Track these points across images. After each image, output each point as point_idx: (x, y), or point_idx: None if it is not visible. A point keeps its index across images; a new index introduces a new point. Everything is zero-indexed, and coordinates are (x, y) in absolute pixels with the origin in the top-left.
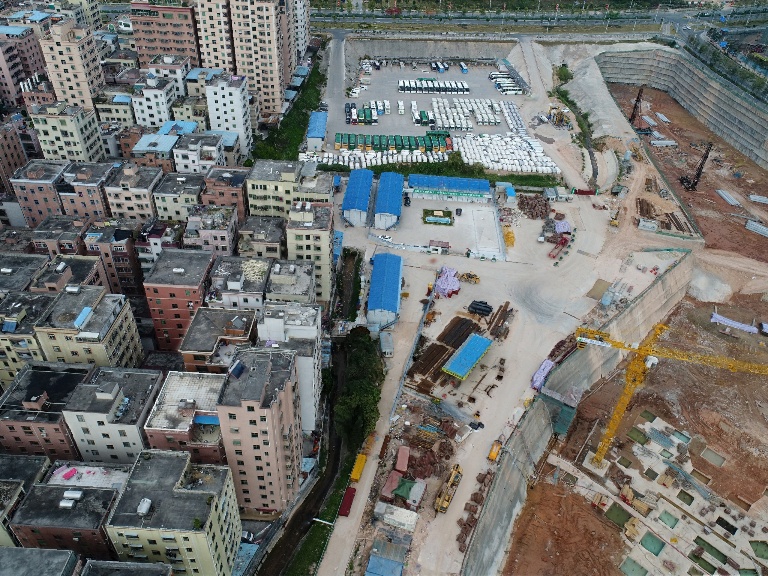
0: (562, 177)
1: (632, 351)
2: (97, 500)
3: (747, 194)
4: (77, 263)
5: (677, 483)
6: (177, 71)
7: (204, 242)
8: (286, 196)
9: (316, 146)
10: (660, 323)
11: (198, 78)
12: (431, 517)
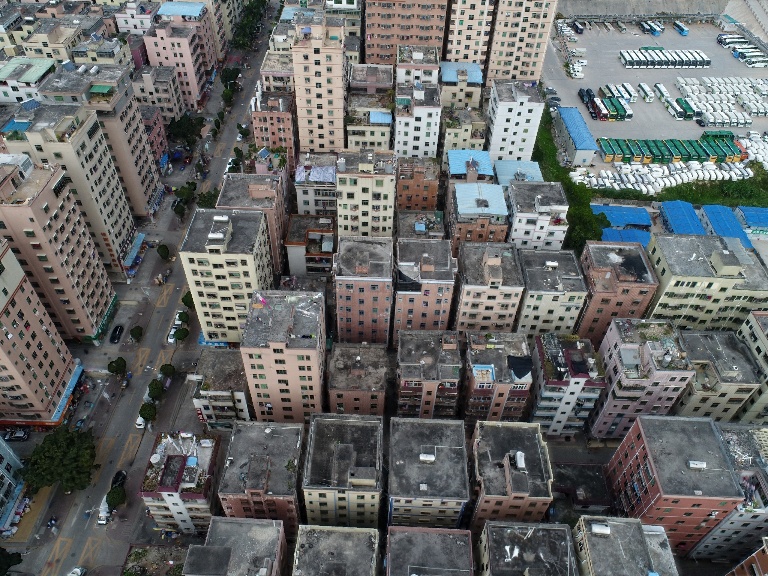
0: None
1: None
2: None
3: None
4: (510, 435)
5: None
6: (434, 72)
7: (652, 383)
8: (717, 294)
9: (585, 160)
10: None
11: (458, 80)
12: None
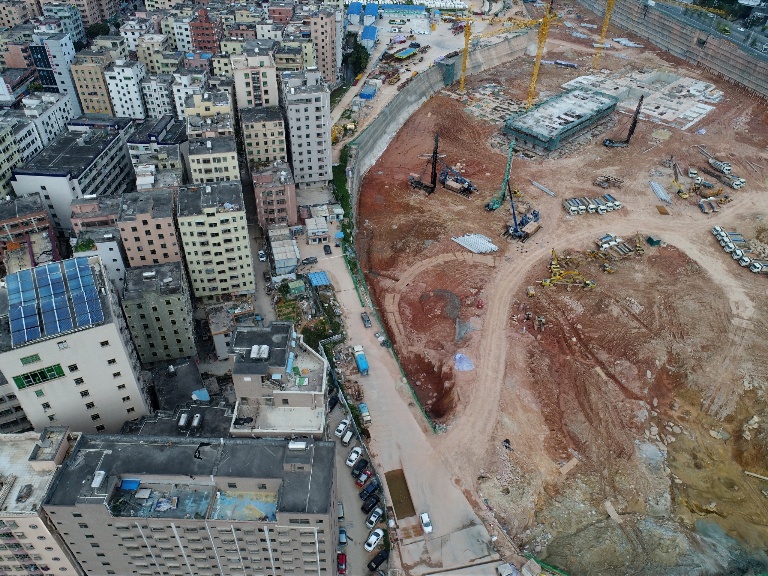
0: (469, 10)
1: (489, 68)
2: None
3: (580, 23)
4: None
5: (494, 96)
6: None
7: None
8: None
9: None
10: (507, 62)
11: None
12: (387, 86)
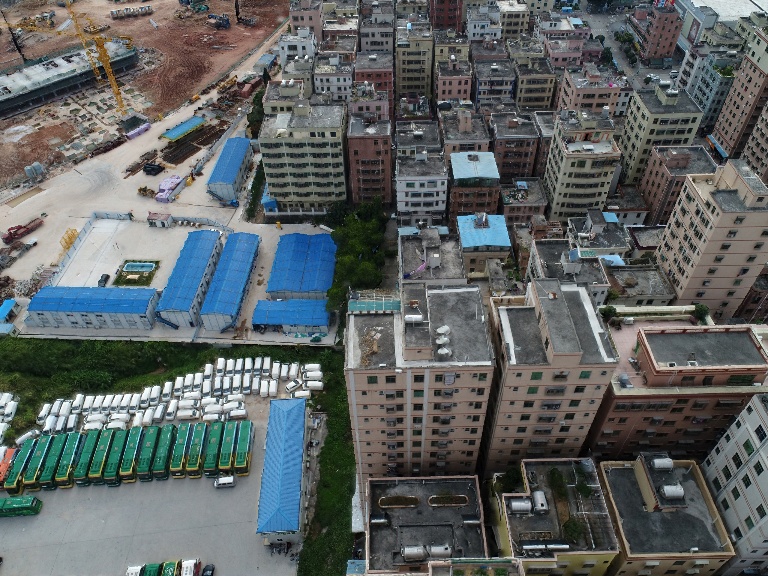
0: None
1: None
2: (367, 6)
3: None
4: None
5: None
6: None
7: None
8: None
9: None
10: None
11: None
12: None
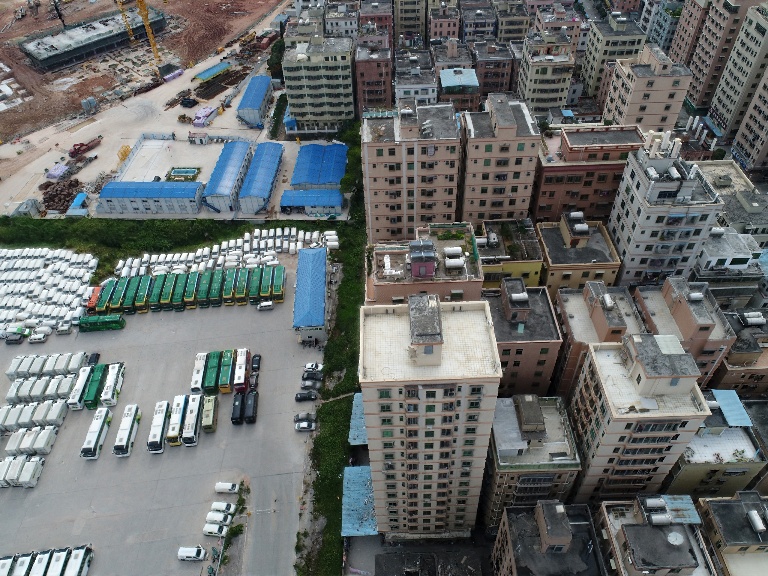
0: None
1: None
2: None
3: None
4: None
5: None
6: None
7: None
8: None
9: None
10: None
11: None
12: None
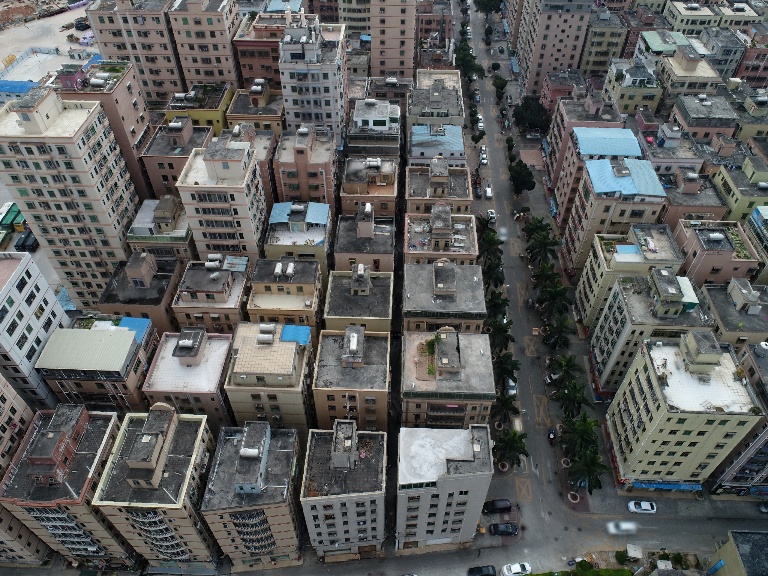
0: None
1: None
2: None
3: None
4: None
5: None
6: None
7: None
8: None
9: None
10: None
11: None
12: None
